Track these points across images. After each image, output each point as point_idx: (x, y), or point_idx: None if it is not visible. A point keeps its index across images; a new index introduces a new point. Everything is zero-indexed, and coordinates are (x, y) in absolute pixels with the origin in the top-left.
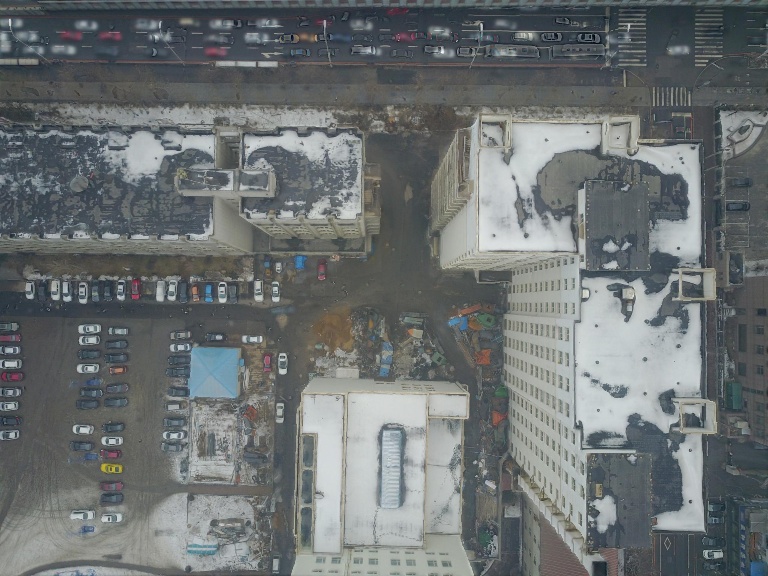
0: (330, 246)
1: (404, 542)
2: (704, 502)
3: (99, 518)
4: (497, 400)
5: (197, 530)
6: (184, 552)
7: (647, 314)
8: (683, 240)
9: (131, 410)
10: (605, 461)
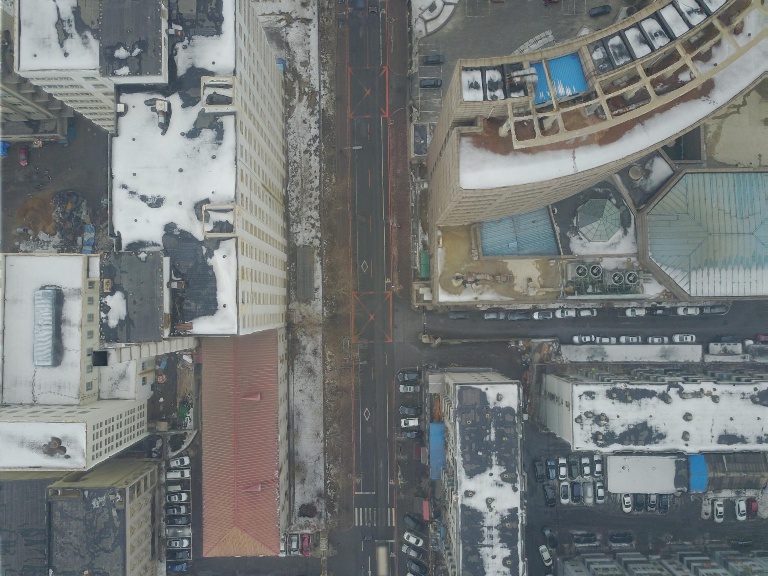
0: (25, 129)
1: (62, 400)
2: (237, 305)
3: None
4: None
5: None
6: None
7: (183, 127)
8: (218, 55)
9: None
10: (117, 259)
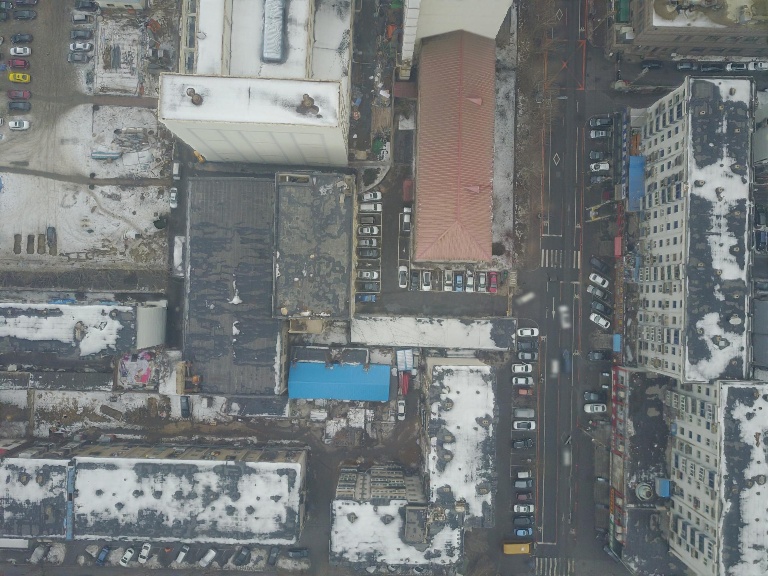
0: None
1: None
2: None
3: (7, 126)
4: (392, 10)
5: (102, 139)
6: (89, 159)
7: None
8: None
9: (40, 24)
10: None
